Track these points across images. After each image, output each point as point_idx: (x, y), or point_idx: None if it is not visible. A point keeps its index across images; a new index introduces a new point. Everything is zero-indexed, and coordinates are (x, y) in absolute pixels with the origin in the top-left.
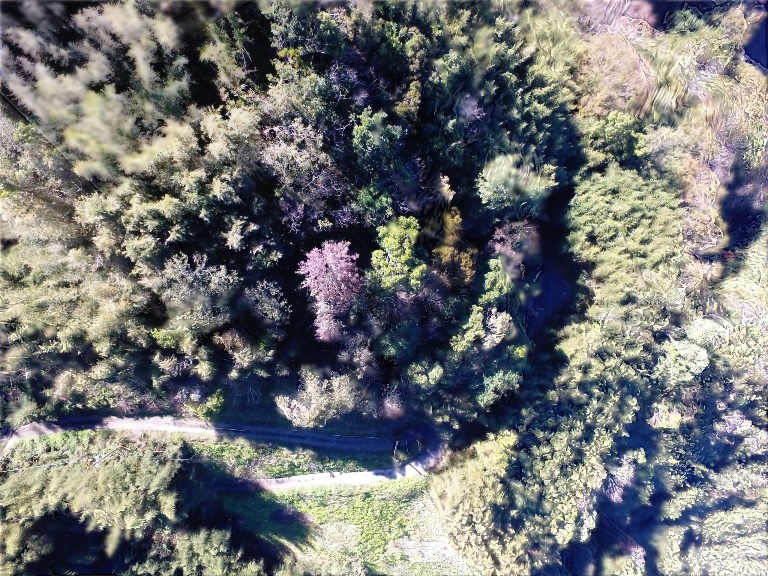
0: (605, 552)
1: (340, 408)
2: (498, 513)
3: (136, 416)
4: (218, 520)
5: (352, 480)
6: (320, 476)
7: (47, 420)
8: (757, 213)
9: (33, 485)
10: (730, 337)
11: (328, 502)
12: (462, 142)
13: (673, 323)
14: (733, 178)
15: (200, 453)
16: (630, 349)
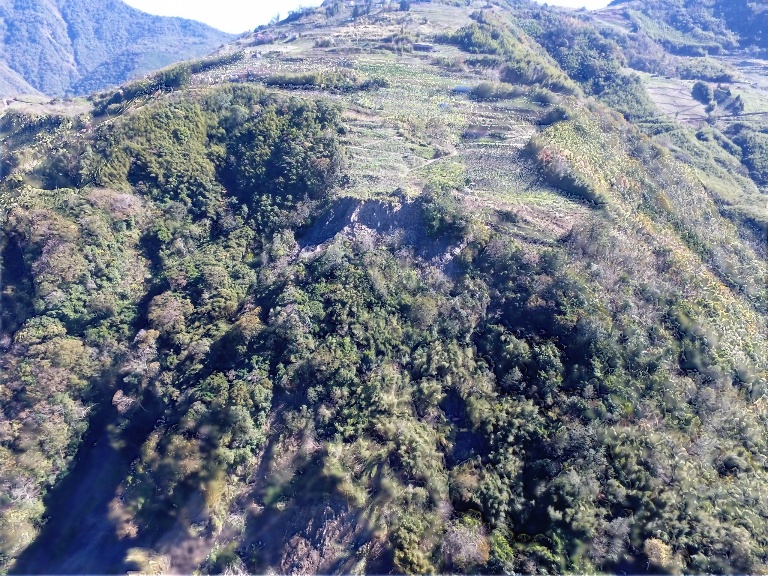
0: None
1: None
2: None
3: None
4: None
5: None
6: None
7: None
8: None
9: None
10: None
11: None
12: (94, 150)
13: None
14: None
15: None
16: None
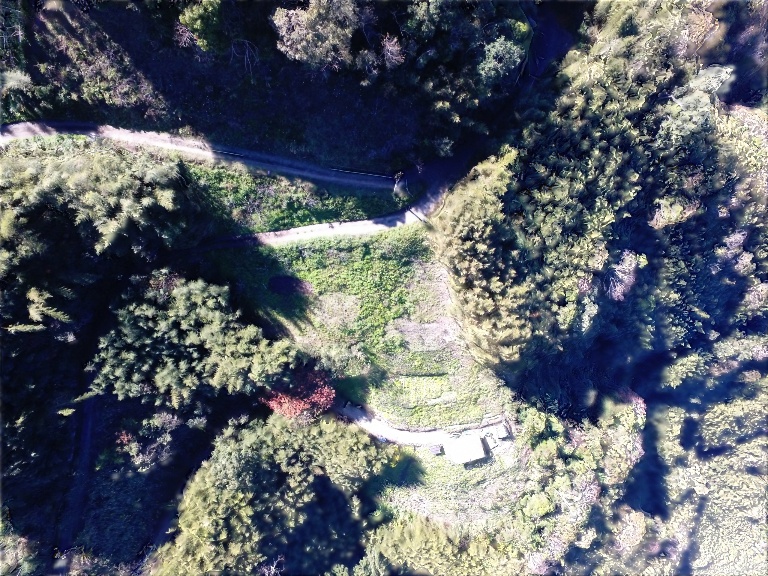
0: (606, 396)
1: (339, 41)
2: (499, 245)
3: (132, 128)
4: (216, 278)
5: (351, 230)
6: (319, 227)
7: (41, 106)
8: (758, 88)
9: (27, 168)
10: (732, 133)
11: (327, 261)
12: None
13: (675, 82)
14: (735, 20)
15: (197, 181)
16: (632, 101)
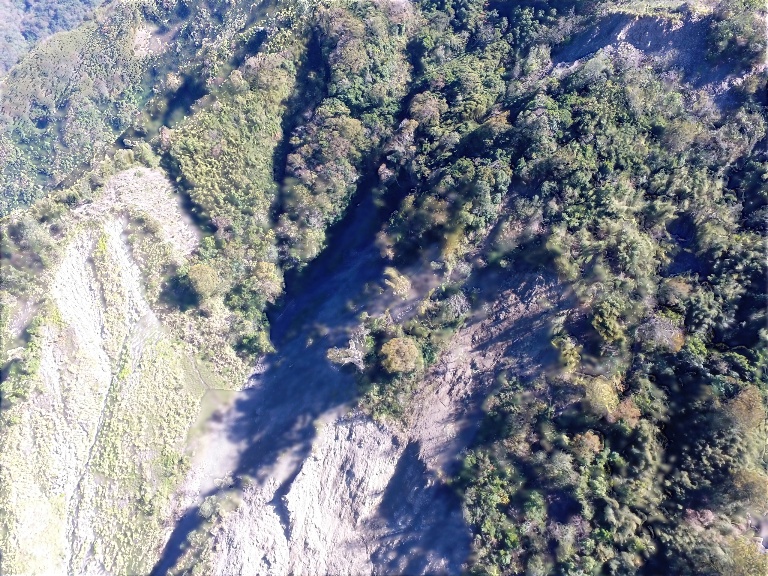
0: (228, 70)
1: None
2: None
3: None
4: None
5: None
6: None
7: None
8: None
9: None
10: None
11: None
12: None
13: None
14: None
15: None
16: None
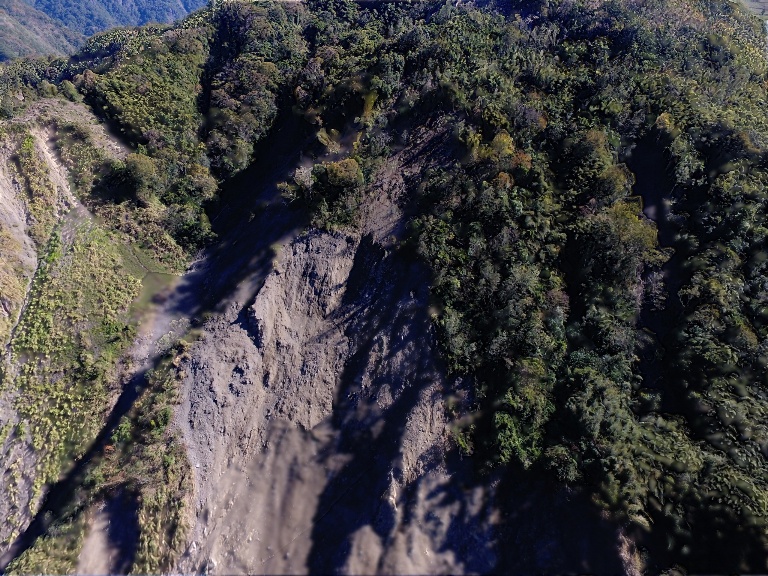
0: None
1: None
2: None
3: None
4: None
5: None
6: None
7: None
8: None
9: None
10: None
11: None
12: None
13: None
14: None
15: None
16: None
